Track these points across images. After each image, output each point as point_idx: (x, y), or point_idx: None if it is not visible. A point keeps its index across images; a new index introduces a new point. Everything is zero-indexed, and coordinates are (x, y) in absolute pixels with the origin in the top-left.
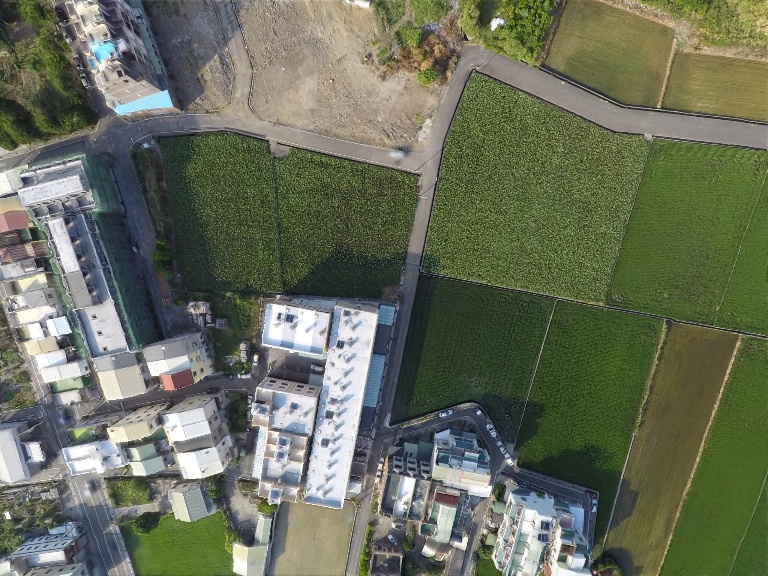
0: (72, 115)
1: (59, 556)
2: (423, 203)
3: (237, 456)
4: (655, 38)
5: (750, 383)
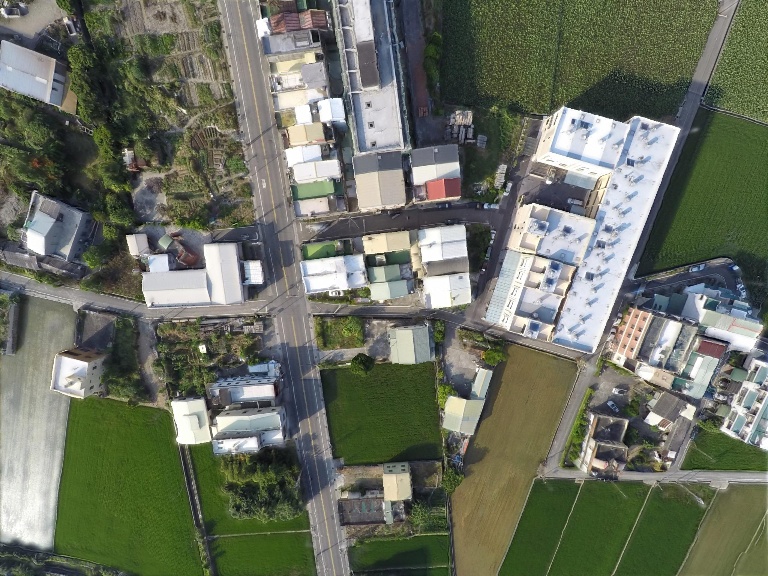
0: None
1: (266, 391)
2: (721, 23)
3: None
4: None
5: None
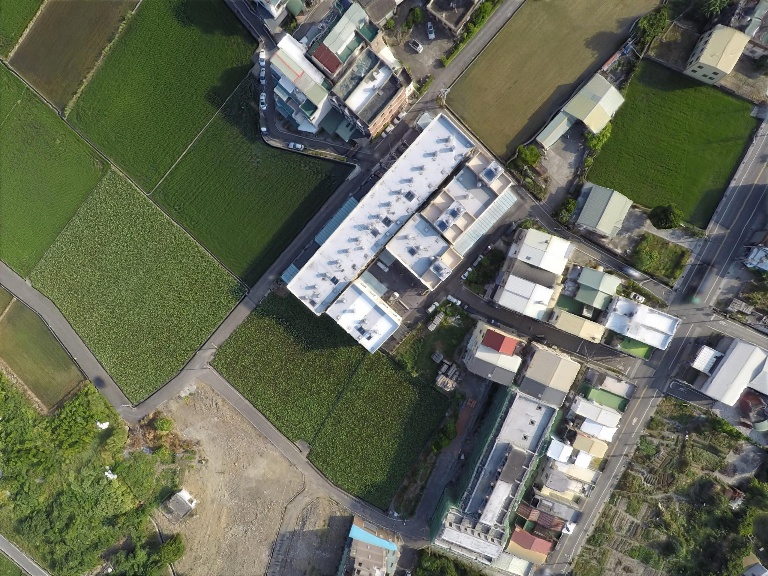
0: (427, 568)
1: None
2: (217, 342)
3: (519, 229)
4: (3, 346)
5: (12, 4)
